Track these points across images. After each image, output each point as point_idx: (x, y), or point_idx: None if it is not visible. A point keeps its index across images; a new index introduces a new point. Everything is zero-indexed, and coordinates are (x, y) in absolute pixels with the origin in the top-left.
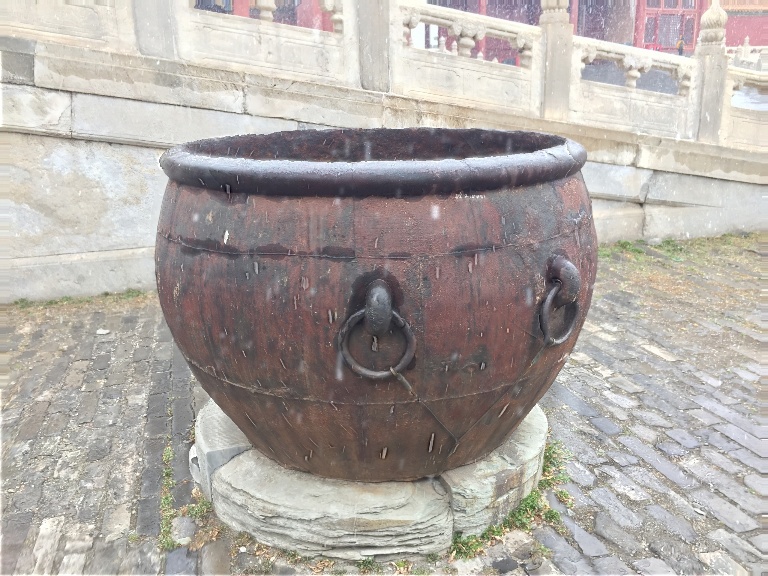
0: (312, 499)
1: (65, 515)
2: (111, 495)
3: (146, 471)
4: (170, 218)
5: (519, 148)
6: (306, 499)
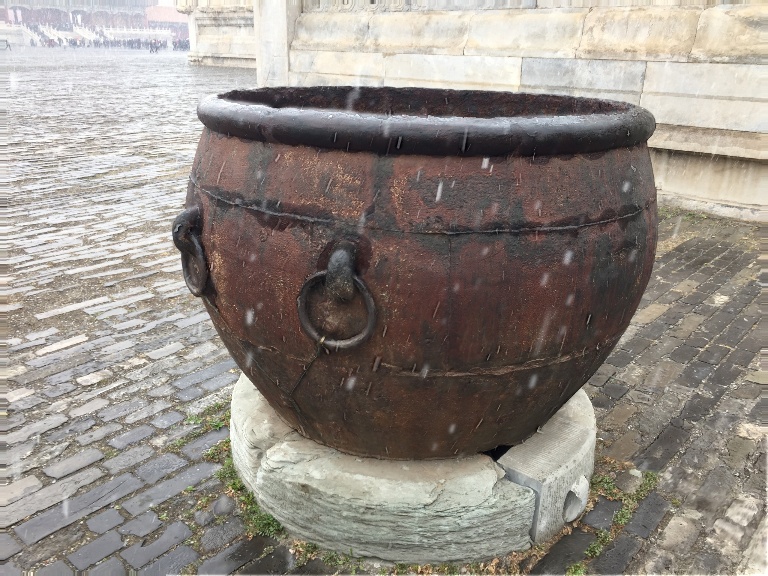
0: None
1: (735, 575)
2: (673, 568)
3: (616, 572)
4: None
5: None
6: None
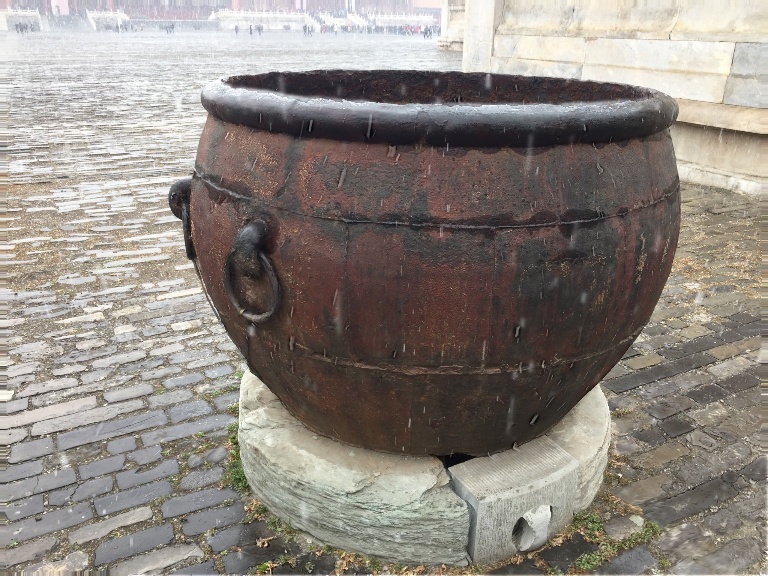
0: (597, 391)
1: None
2: None
3: None
4: (649, 180)
5: (315, 90)
6: (598, 394)
